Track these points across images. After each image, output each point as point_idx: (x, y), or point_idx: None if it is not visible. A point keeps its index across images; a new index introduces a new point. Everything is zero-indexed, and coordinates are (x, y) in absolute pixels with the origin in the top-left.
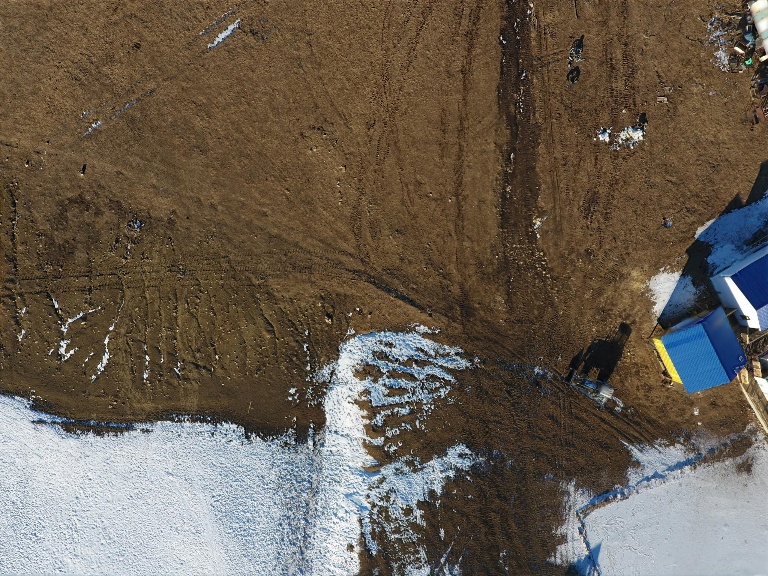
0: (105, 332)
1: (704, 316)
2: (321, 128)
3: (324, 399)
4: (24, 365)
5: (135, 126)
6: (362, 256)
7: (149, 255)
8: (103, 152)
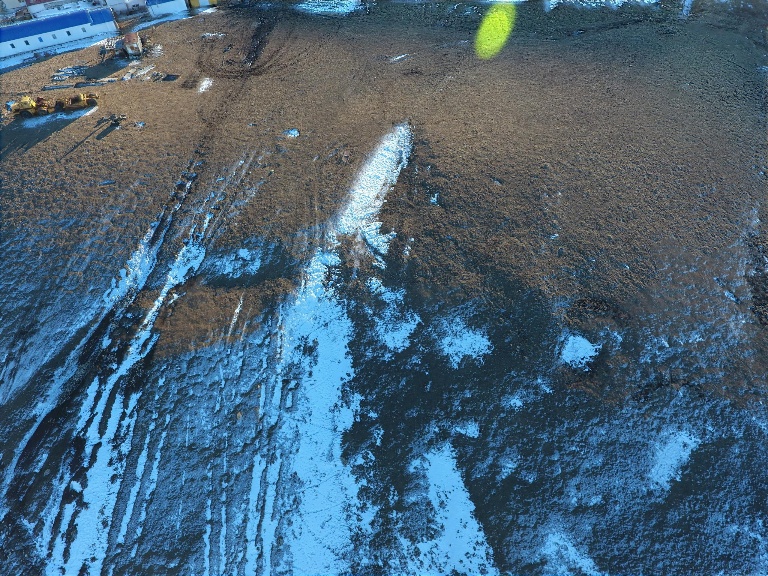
0: None
1: (198, 4)
2: None
3: None
4: (492, 5)
5: None
6: None
7: None
8: None
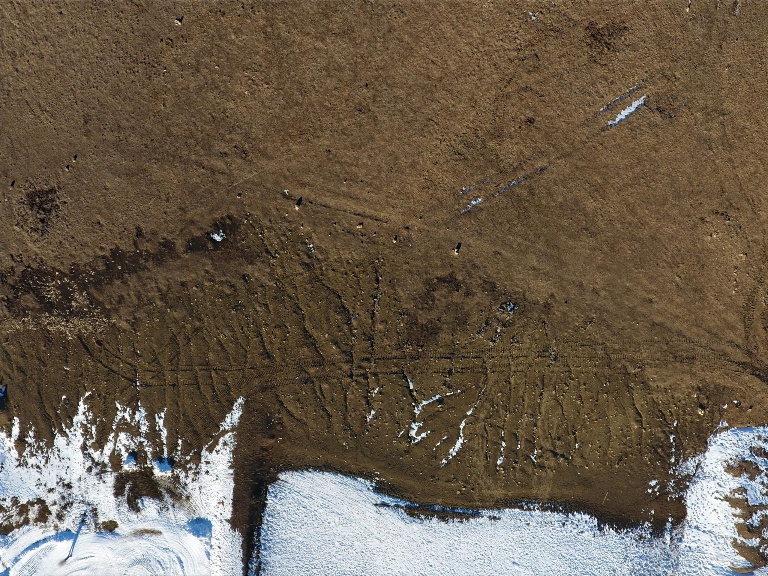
0: (462, 416)
1: None
2: (725, 213)
3: (686, 493)
4: (371, 446)
5: (521, 205)
6: (749, 347)
7: (520, 339)
8: (482, 231)
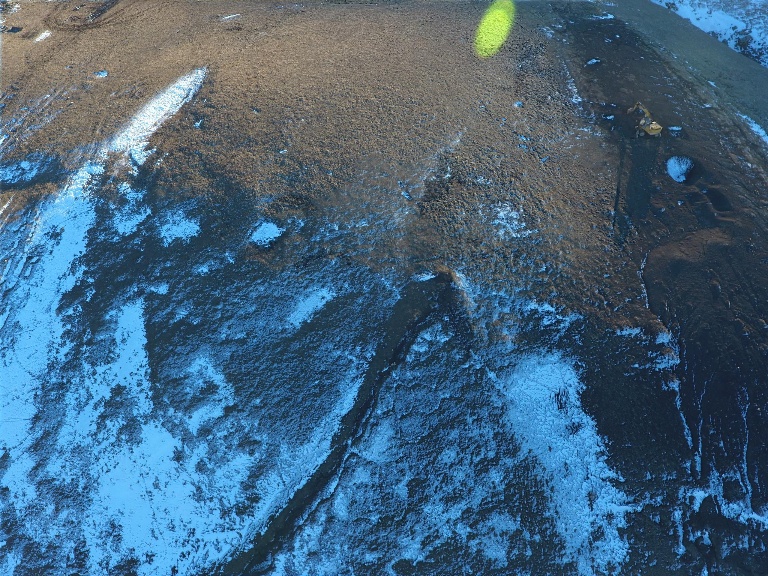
0: None
1: None
2: None
3: None
4: None
5: (280, 3)
6: None
7: None
8: (296, 0)
